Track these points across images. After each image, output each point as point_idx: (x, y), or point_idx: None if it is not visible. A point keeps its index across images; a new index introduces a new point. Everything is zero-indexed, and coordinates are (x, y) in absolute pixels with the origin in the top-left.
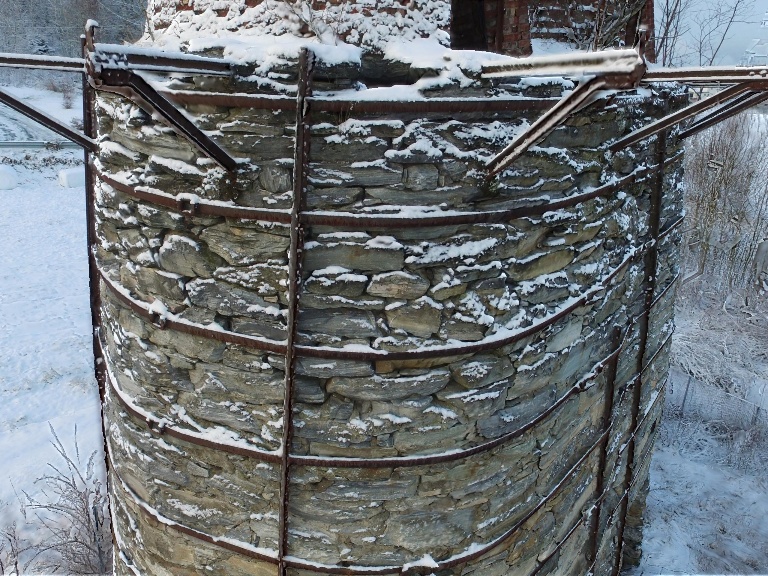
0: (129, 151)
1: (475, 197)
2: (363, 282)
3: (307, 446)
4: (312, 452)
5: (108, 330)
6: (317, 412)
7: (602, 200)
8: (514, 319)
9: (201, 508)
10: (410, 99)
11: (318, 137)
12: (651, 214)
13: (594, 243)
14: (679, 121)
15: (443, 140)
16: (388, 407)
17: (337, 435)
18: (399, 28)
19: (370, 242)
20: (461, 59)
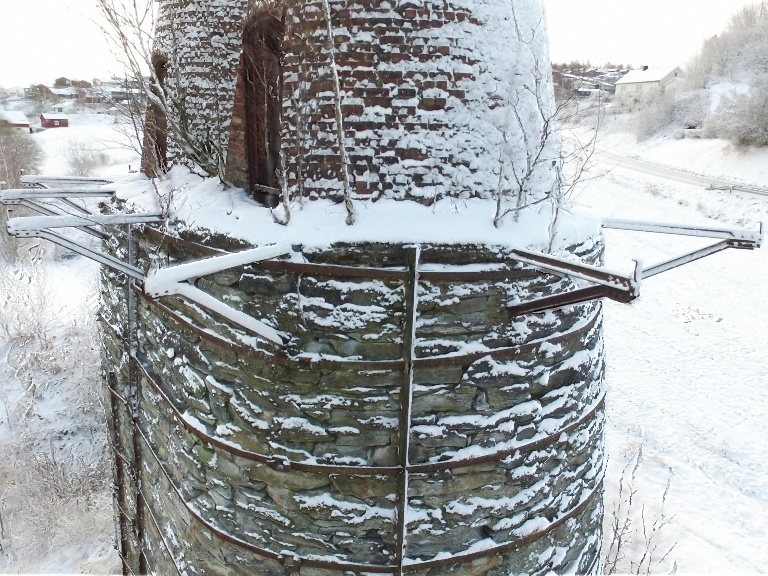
0: None
1: None
2: None
3: None
4: None
5: None
6: None
7: None
8: None
9: None
10: None
11: None
12: None
13: (104, 287)
14: None
15: None
16: None
17: None
18: None
19: None
20: None
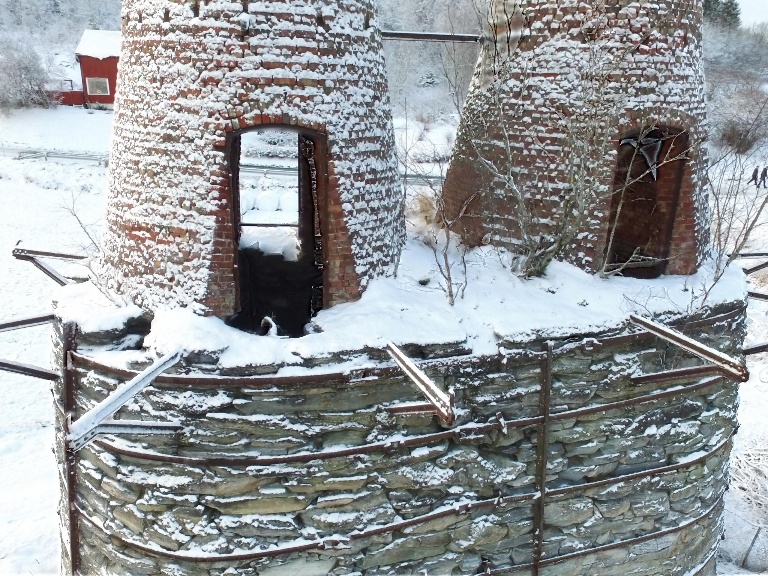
0: None
1: (175, 443)
2: (98, 479)
3: (88, 569)
4: (88, 575)
5: None
6: (90, 550)
7: (371, 456)
8: (211, 544)
9: (66, 574)
10: (119, 368)
11: (83, 375)
12: (538, 465)
13: (347, 495)
14: (411, 413)
15: (143, 399)
16: (120, 569)
17: (96, 572)
18: (166, 298)
19: (101, 455)
20: (158, 344)
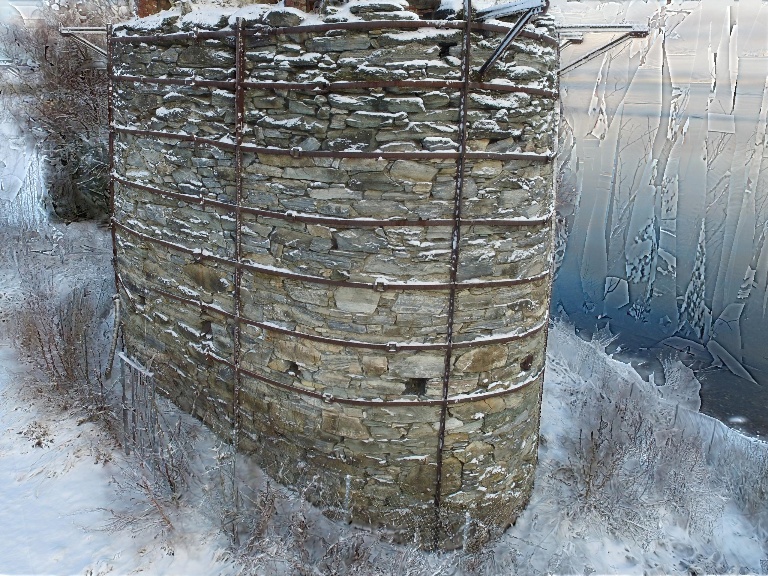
0: (536, 70)
1: None
2: None
3: None
4: None
5: (508, 193)
6: None
7: None
8: None
9: None
10: None
11: None
12: None
13: None
14: None
15: None
16: None
17: None
18: None
19: None
20: None
